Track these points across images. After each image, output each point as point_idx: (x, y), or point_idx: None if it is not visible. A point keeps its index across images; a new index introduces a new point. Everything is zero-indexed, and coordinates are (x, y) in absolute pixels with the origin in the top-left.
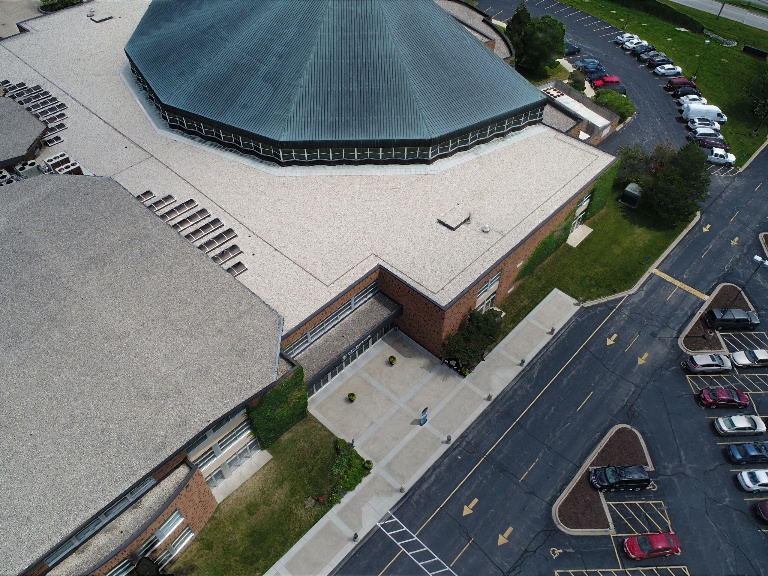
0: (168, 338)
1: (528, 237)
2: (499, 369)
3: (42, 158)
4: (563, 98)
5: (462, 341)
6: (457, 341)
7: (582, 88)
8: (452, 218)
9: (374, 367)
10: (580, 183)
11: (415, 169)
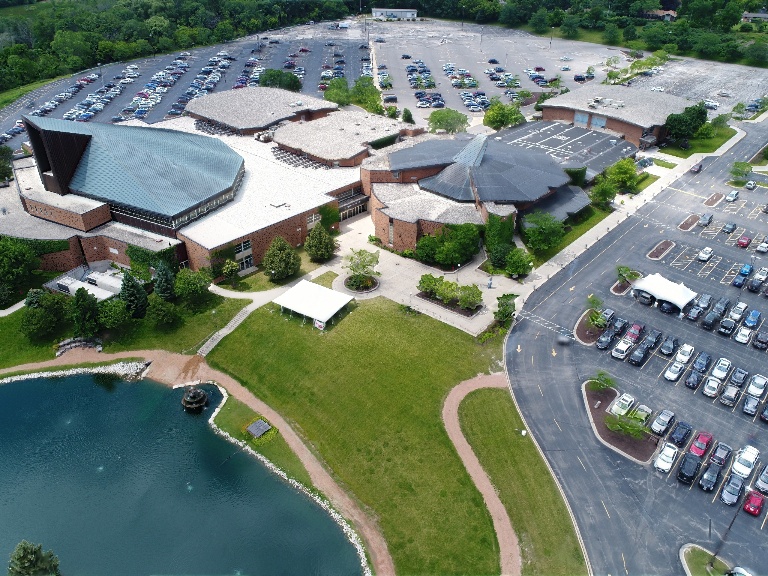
0: None
1: None
2: None
3: None
4: None
5: None
6: None
7: None
8: None
9: None
10: None
11: None
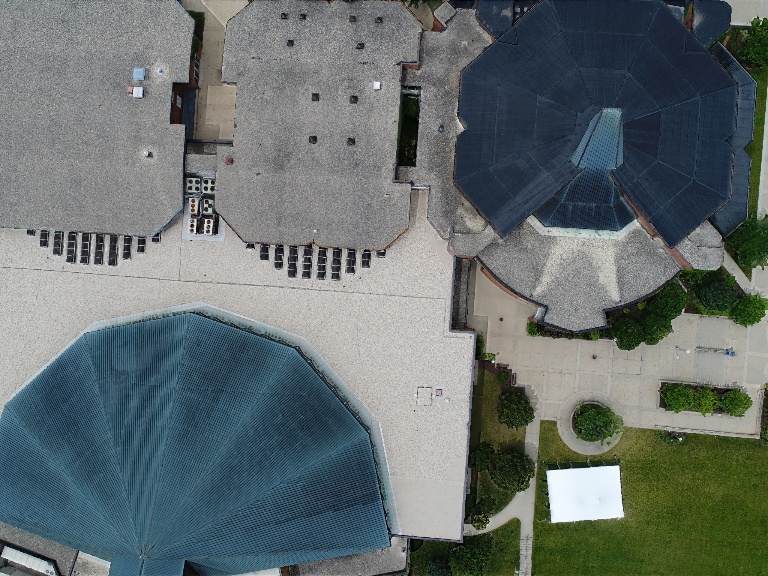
0: (0, 174)
1: None
2: None
3: None
4: None
5: None
6: None
7: None
8: None
9: None
10: None
11: None
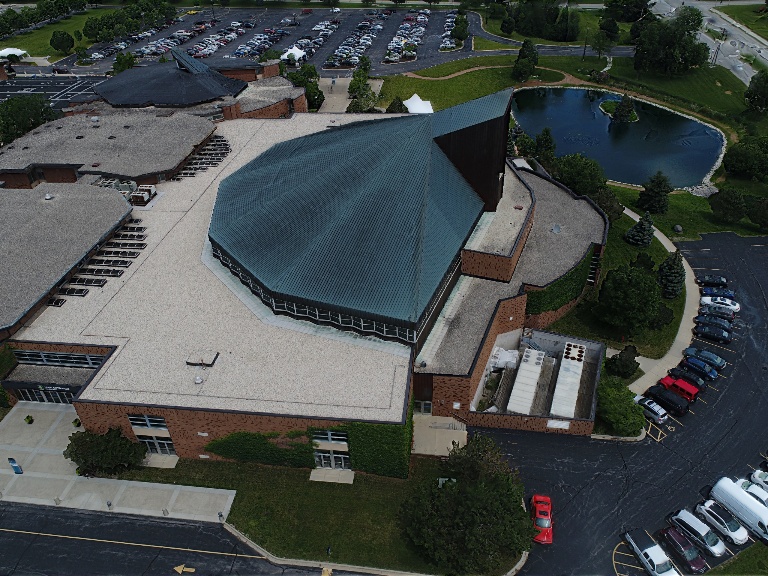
0: None
1: (201, 409)
2: (99, 494)
3: (157, 186)
4: (572, 363)
5: (82, 440)
6: (79, 437)
7: (624, 371)
8: (199, 355)
9: (71, 418)
10: (325, 412)
11: (262, 311)
